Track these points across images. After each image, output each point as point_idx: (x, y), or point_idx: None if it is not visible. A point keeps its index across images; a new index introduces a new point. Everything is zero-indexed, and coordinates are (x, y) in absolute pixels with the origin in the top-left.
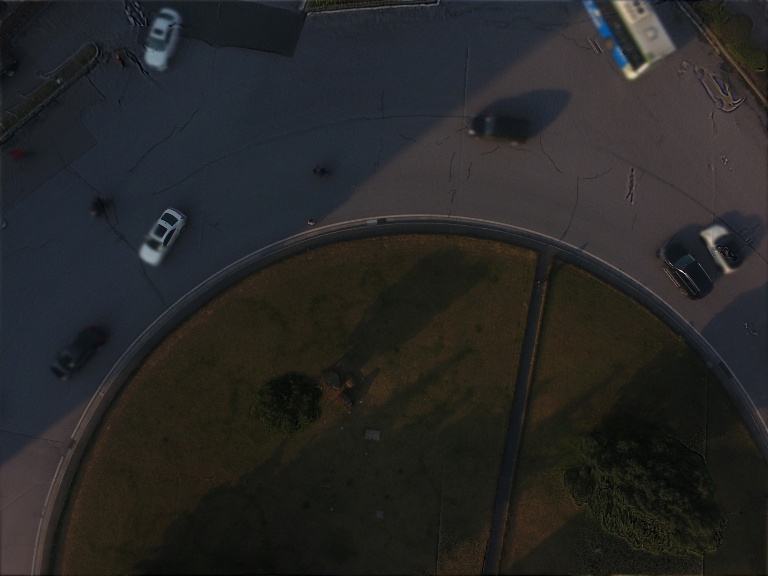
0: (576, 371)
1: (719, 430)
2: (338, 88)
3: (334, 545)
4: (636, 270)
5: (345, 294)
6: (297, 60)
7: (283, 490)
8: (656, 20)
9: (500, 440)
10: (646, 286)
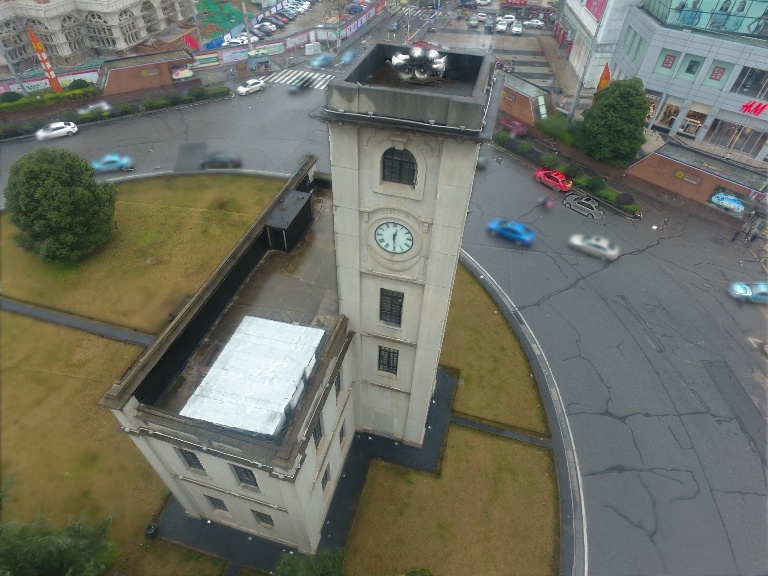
0: None
1: None
2: None
3: None
4: None
5: None
6: None
7: None
8: None
9: (1, 315)
10: None
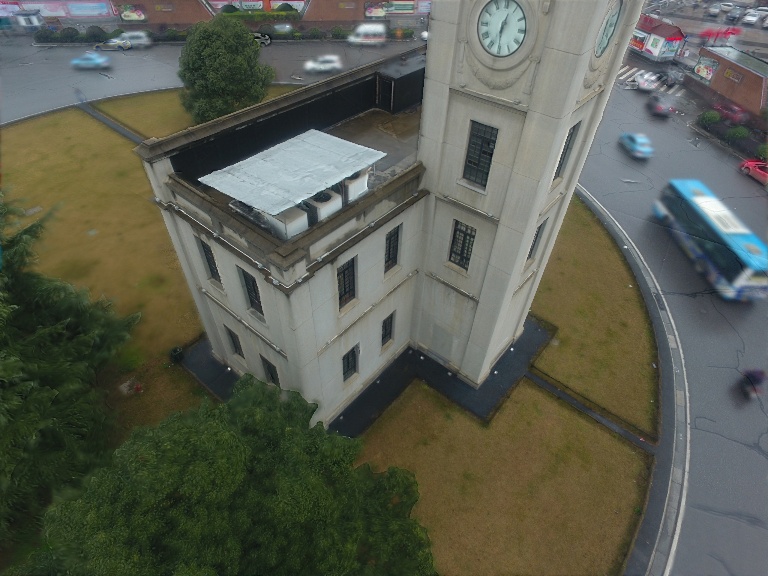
0: (160, 117)
1: None
2: None
3: (67, 273)
4: None
5: None
6: None
7: None
8: (54, 51)
9: None
10: (162, 88)
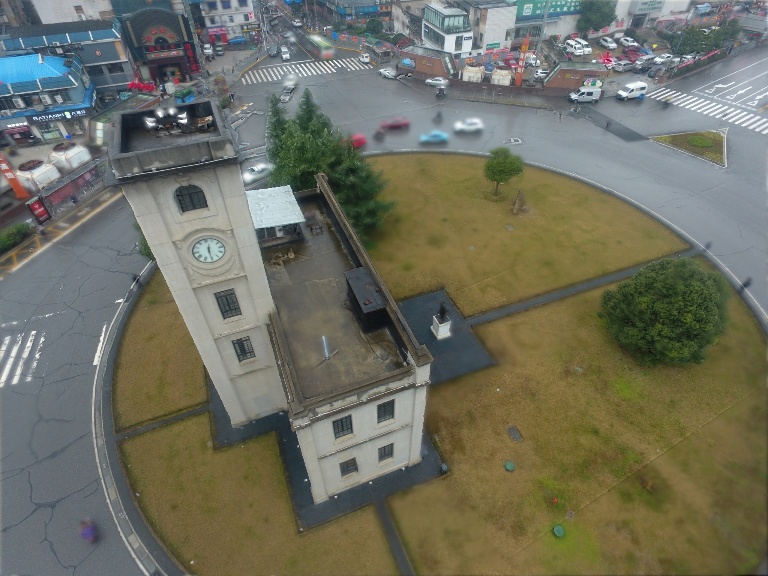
0: None
1: (760, 406)
2: (639, 157)
3: (435, 238)
4: (761, 298)
5: (562, 191)
6: (629, 144)
7: (443, 209)
8: None
9: (577, 280)
10: (762, 308)
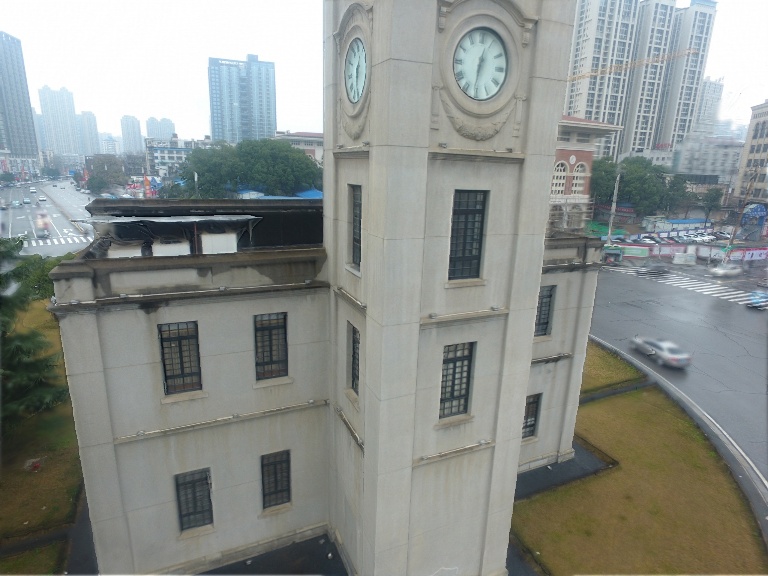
0: None
1: None
2: None
3: None
4: None
5: None
6: None
7: None
8: None
9: None
10: None
